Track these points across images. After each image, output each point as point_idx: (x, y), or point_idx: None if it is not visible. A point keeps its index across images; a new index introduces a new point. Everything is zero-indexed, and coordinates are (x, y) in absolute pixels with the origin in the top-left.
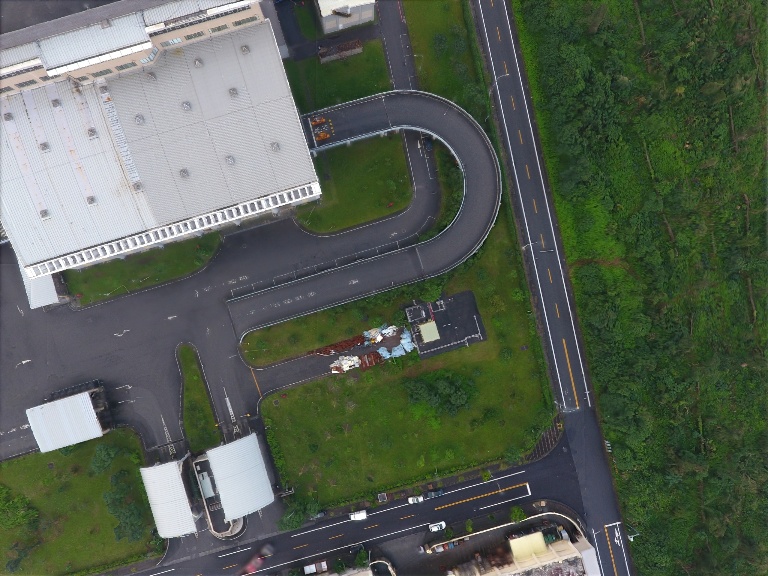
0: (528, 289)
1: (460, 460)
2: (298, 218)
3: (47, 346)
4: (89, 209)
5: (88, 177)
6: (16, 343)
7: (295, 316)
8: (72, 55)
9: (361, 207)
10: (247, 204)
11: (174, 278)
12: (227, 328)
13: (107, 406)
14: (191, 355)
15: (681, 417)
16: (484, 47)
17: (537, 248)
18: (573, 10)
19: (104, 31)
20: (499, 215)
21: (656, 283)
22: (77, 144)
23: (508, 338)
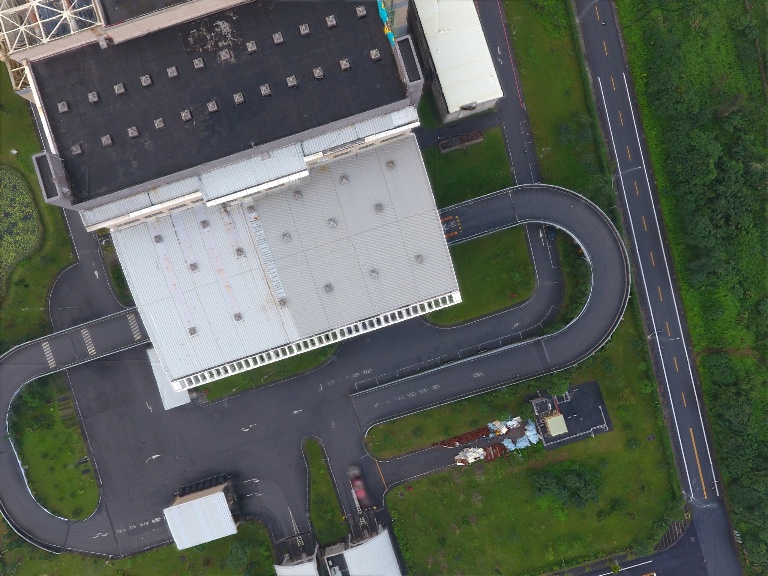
0: (655, 379)
1: (588, 552)
2: None
3: (176, 441)
4: (235, 325)
5: (235, 295)
6: (146, 438)
7: (420, 409)
8: (231, 186)
9: (483, 298)
10: (388, 314)
11: (298, 372)
12: (352, 421)
13: (236, 499)
14: (317, 449)
15: None
16: (606, 132)
17: (663, 337)
18: (699, 92)
19: (263, 162)
20: None
21: None
22: (225, 263)
23: (634, 428)
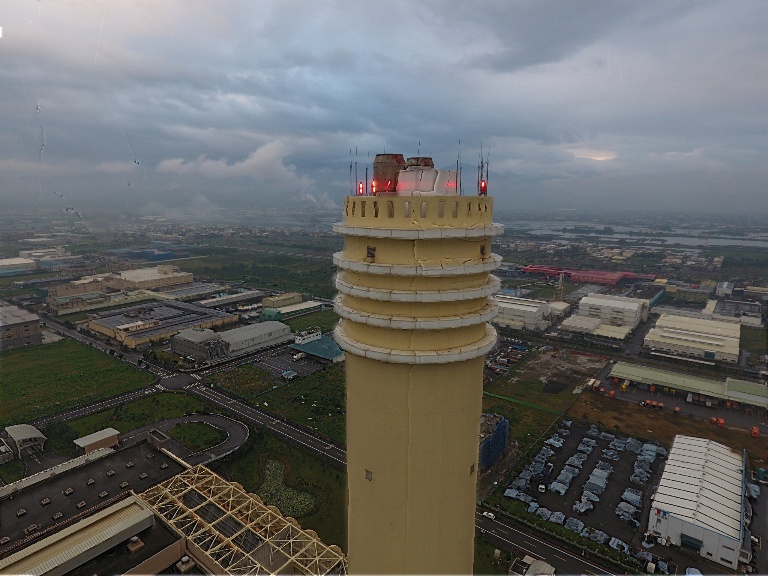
0: None
1: None
2: None
3: None
4: None
5: None
6: None
7: None
8: None
9: None
10: None
11: None
12: None
13: None
14: None
15: None
16: None
17: None
18: None
19: None
20: None
21: None
22: None
23: None
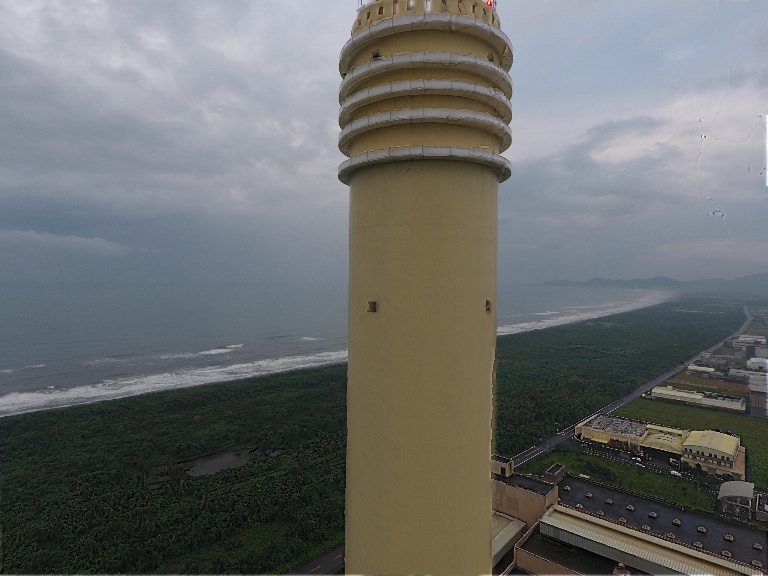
0: None
1: None
2: None
3: None
4: None
5: None
6: None
7: None
8: None
9: None
10: None
11: None
12: None
13: None
14: None
15: None
16: None
17: None
18: None
19: None
20: None
21: None
22: None
23: None
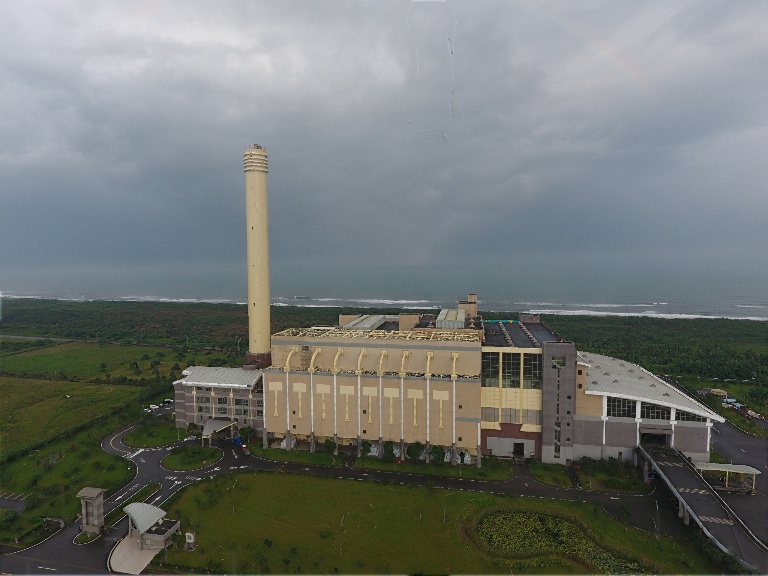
0: None
1: None
2: None
3: None
4: None
5: None
6: None
7: None
8: None
9: None
10: None
11: None
12: None
13: None
14: None
15: None
16: None
17: None
18: None
19: None
20: None
21: None
22: None
23: None
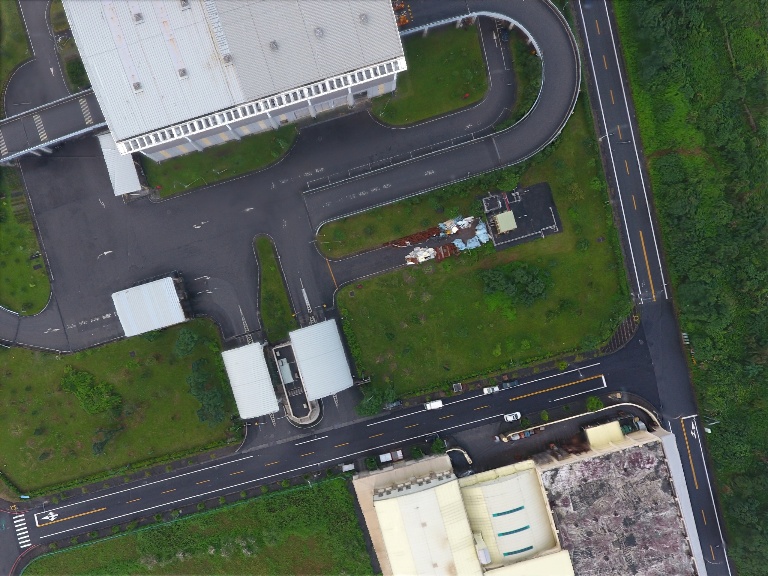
0: (605, 180)
1: (536, 350)
2: (373, 110)
3: (128, 237)
4: (180, 82)
5: (180, 49)
6: (98, 234)
7: (371, 207)
8: None
9: (436, 99)
10: (334, 79)
11: (251, 170)
12: (303, 220)
13: (186, 296)
14: (268, 246)
15: (763, 305)
16: None
17: (614, 139)
18: None
19: None
20: (576, 105)
21: (738, 171)
22: (170, 15)
23: (584, 230)
